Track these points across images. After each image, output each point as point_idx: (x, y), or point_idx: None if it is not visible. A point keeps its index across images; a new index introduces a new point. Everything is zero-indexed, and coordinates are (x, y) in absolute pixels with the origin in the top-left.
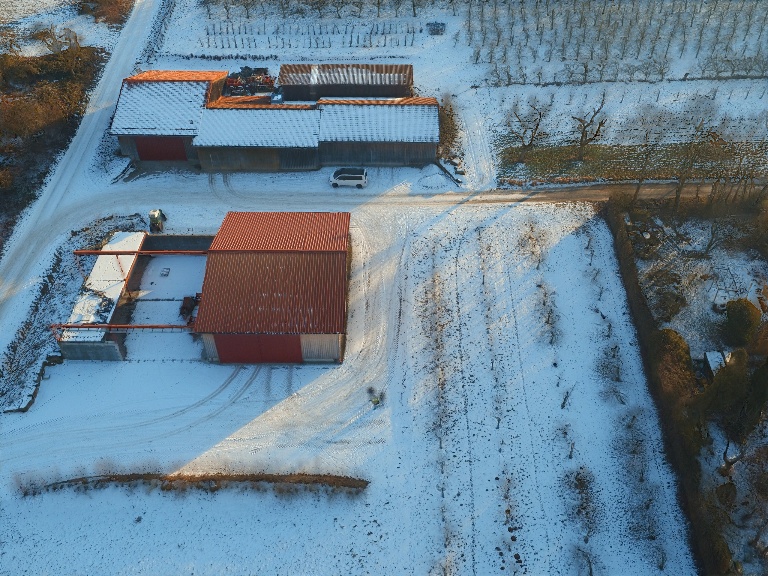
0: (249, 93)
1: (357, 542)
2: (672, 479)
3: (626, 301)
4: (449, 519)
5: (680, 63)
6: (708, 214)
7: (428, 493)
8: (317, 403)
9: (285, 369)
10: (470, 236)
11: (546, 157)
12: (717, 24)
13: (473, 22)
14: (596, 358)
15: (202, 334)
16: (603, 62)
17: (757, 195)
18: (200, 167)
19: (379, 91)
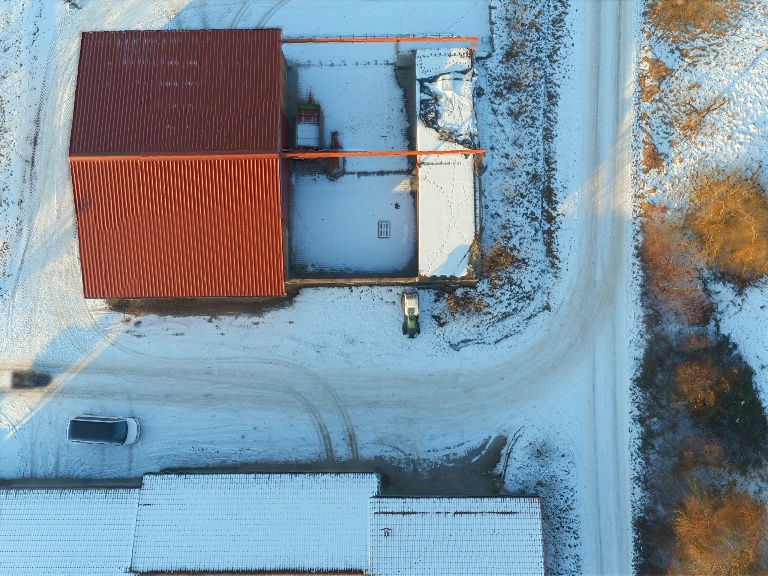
0: None
1: None
2: None
3: None
4: None
5: None
6: None
7: None
8: (144, 4)
9: None
10: None
11: None
12: None
13: None
14: None
15: None
16: None
17: None
18: None
19: None
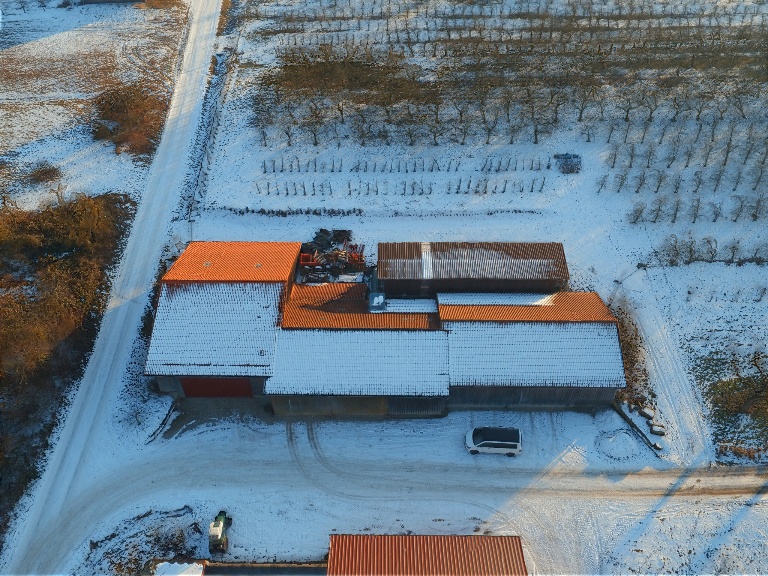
0: (331, 277)
1: None
2: None
3: None
4: None
5: None
6: None
7: None
8: None
9: None
10: (701, 568)
11: None
12: None
13: None
14: None
15: None
16: None
17: None
18: (272, 410)
19: (519, 284)
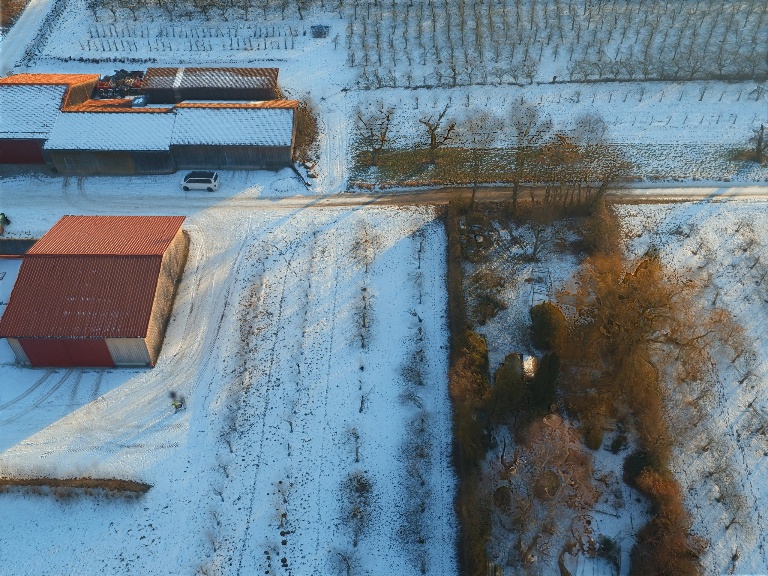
0: (119, 96)
1: (128, 546)
2: (453, 483)
3: (446, 304)
4: (224, 523)
5: (553, 66)
6: (546, 217)
7: (209, 497)
8: (120, 407)
9: (96, 373)
10: (307, 239)
11: (400, 160)
12: (593, 27)
13: (357, 25)
14: (404, 362)
15: (7, 338)
16: (472, 65)
17: (592, 198)
18: (57, 170)
19: (243, 94)
